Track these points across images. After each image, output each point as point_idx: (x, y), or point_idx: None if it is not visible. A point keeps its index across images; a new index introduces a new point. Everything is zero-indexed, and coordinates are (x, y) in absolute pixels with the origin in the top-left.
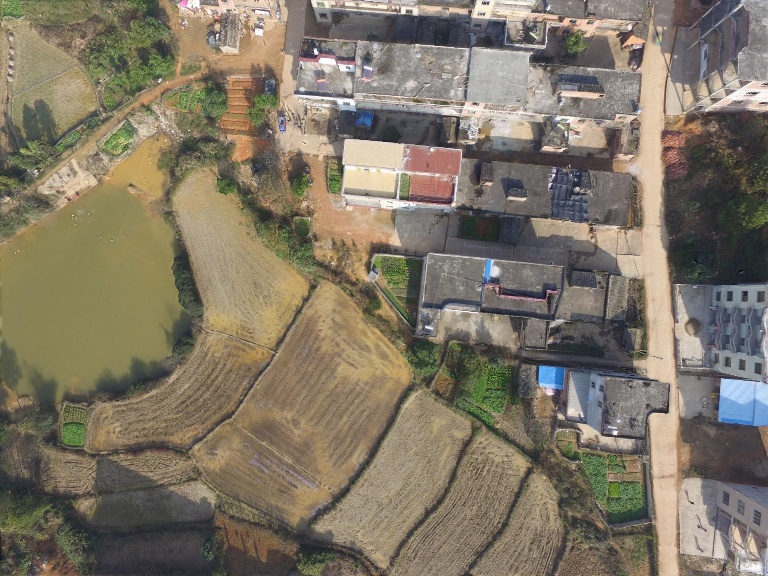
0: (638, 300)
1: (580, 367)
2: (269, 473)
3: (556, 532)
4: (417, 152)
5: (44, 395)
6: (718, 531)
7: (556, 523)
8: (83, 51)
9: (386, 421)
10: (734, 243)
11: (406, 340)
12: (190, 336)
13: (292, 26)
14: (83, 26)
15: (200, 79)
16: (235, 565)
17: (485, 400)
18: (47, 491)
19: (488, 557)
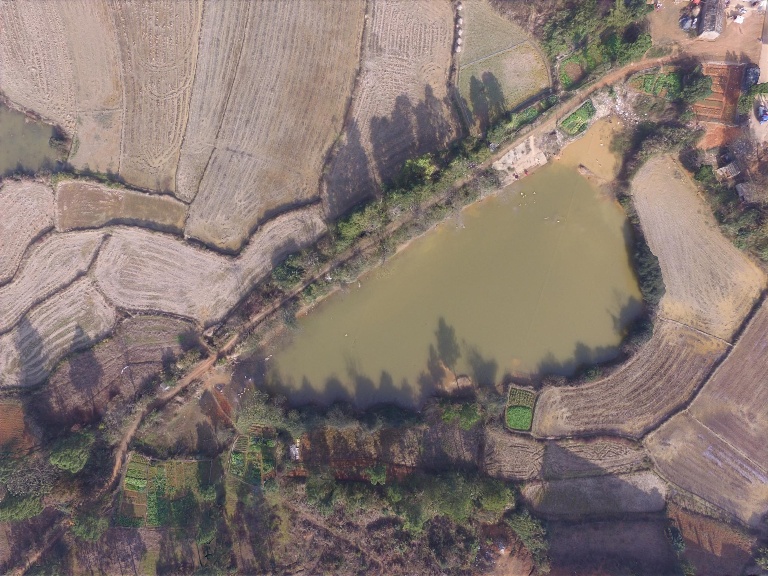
0: None
1: None
2: (723, 466)
3: None
4: None
5: (483, 376)
6: None
7: None
8: (541, 26)
9: None
10: None
11: None
12: (651, 323)
13: None
14: (539, 0)
15: (669, 63)
16: (688, 558)
17: None
18: (491, 475)
19: None
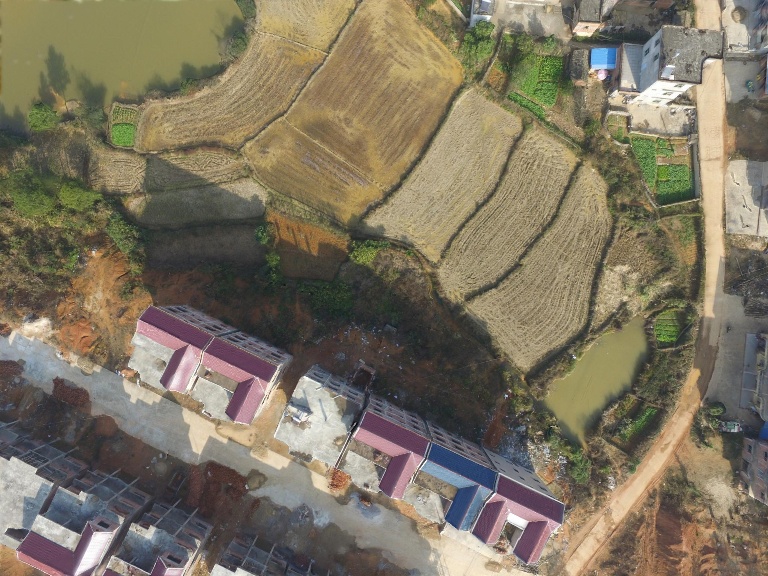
0: None
1: None
2: (321, 171)
3: (604, 223)
4: None
5: (92, 100)
6: (763, 210)
7: (604, 214)
8: None
9: (438, 120)
10: None
11: (459, 36)
12: (243, 33)
13: None
14: None
15: None
16: (286, 259)
17: (537, 92)
18: (95, 190)
19: (538, 247)
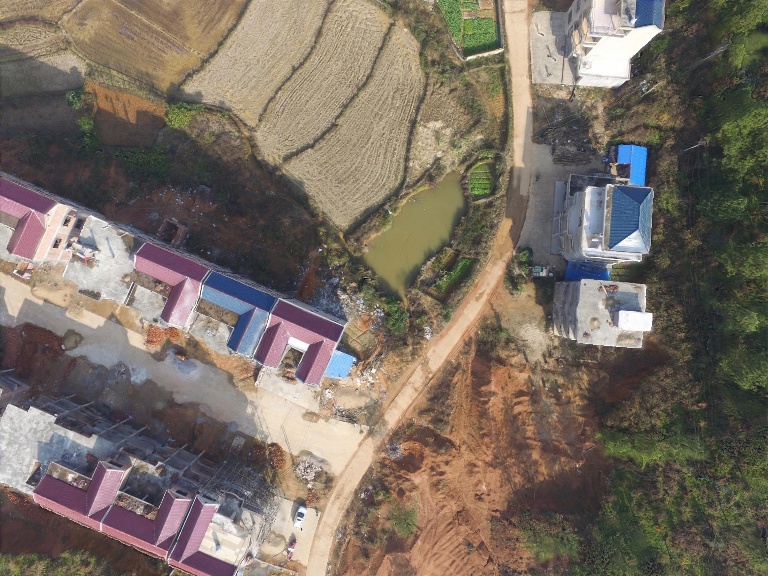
0: None
1: None
2: (139, 41)
3: (418, 81)
4: None
5: None
6: (566, 58)
7: (418, 73)
8: None
9: None
10: None
11: None
12: None
13: None
14: None
15: None
16: (105, 127)
17: None
18: None
19: (353, 107)
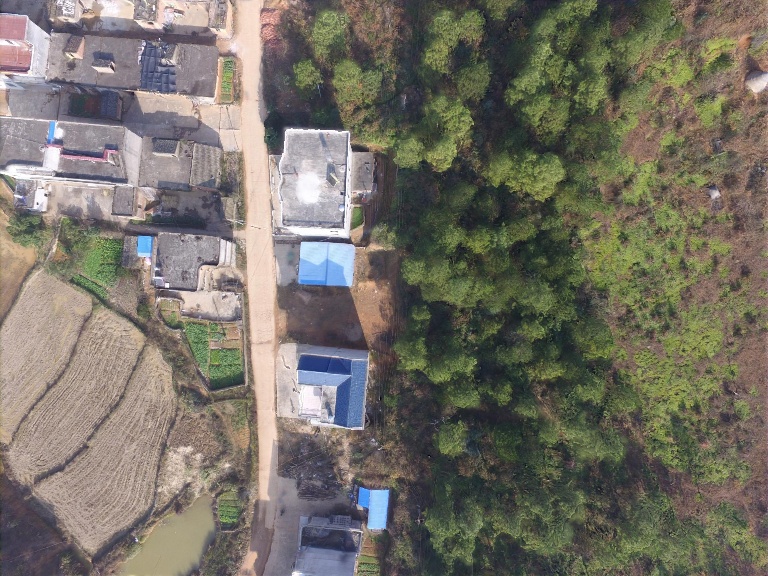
0: (238, 172)
1: None
2: None
3: (170, 403)
4: None
5: None
6: None
7: (170, 394)
8: None
9: (11, 300)
10: None
11: None
12: None
13: None
14: None
15: None
16: None
17: (98, 274)
18: None
19: (104, 429)
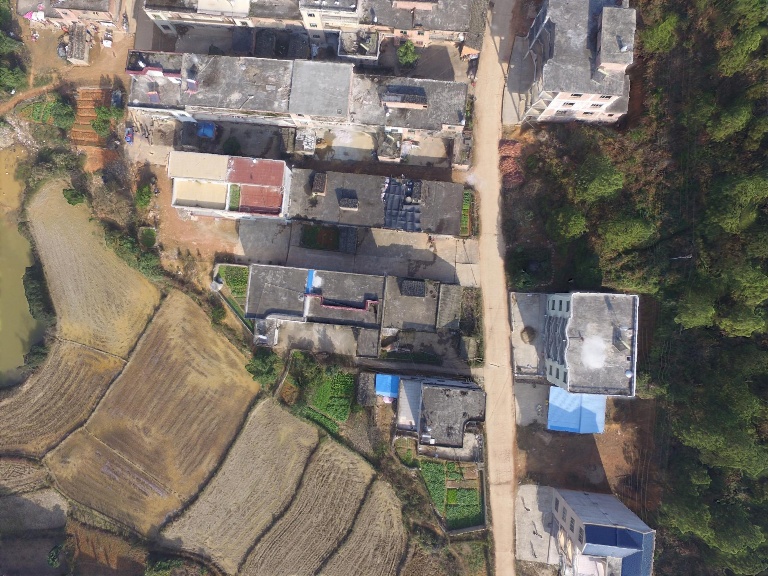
0: (476, 308)
1: (419, 375)
2: (120, 481)
3: (400, 538)
4: (241, 164)
5: None
6: (553, 537)
7: (400, 529)
8: None
9: (235, 429)
10: (565, 252)
11: (252, 349)
12: (42, 345)
13: (140, 37)
14: None
15: (52, 90)
16: (86, 572)
17: (328, 408)
18: None
19: (333, 563)
